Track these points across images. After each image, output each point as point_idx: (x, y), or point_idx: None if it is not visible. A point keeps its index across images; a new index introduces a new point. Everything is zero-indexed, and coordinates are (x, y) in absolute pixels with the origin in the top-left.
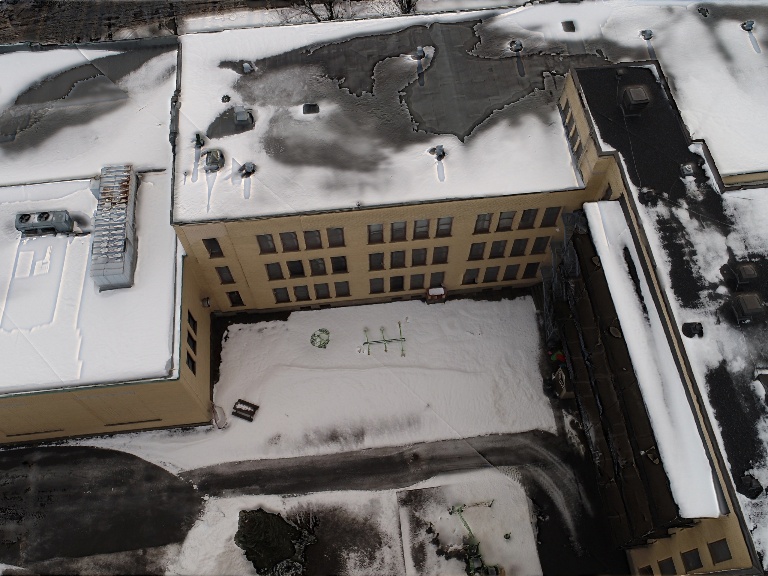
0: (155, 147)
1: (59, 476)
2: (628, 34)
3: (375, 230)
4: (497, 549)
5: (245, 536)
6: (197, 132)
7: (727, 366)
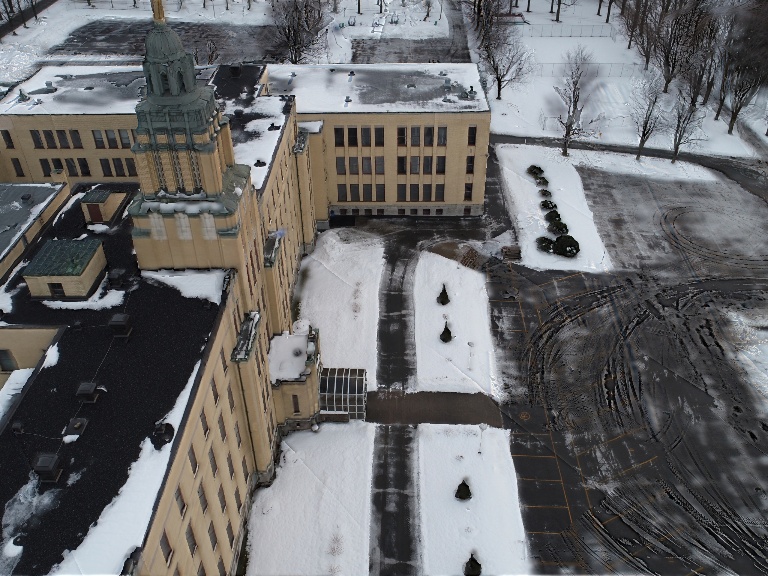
0: None
1: None
2: (283, 75)
3: (99, 137)
4: None
5: None
6: (24, 92)
7: None
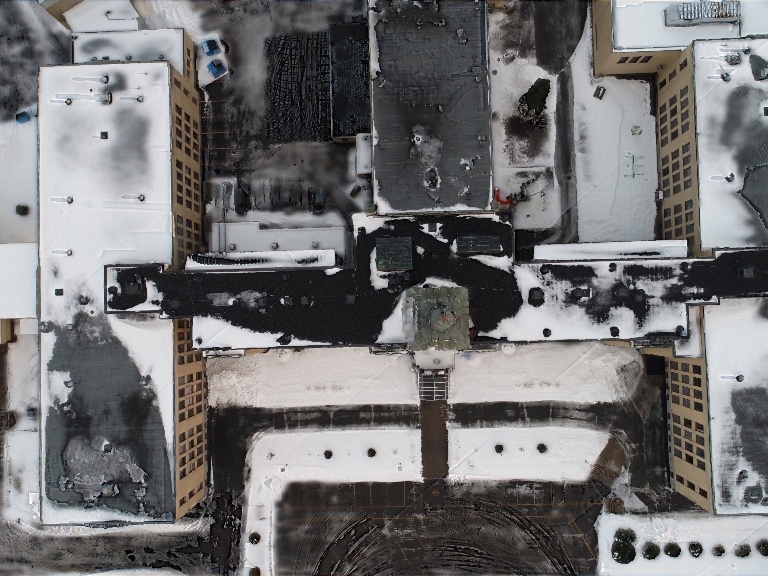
0: (757, 29)
1: (573, 4)
2: None
3: (689, 147)
4: (524, 211)
5: (540, 81)
6: (755, 49)
7: (595, 277)
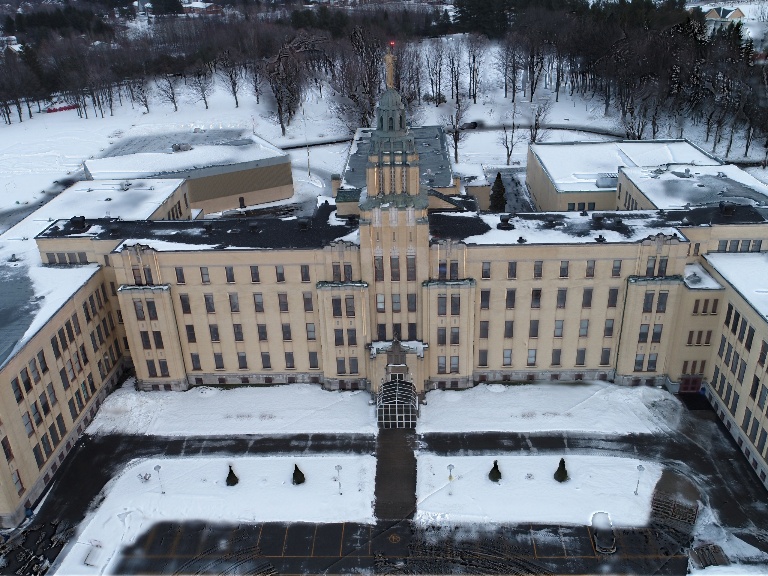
0: None
1: None
2: None
3: None
4: None
5: None
6: None
7: (567, 218)
